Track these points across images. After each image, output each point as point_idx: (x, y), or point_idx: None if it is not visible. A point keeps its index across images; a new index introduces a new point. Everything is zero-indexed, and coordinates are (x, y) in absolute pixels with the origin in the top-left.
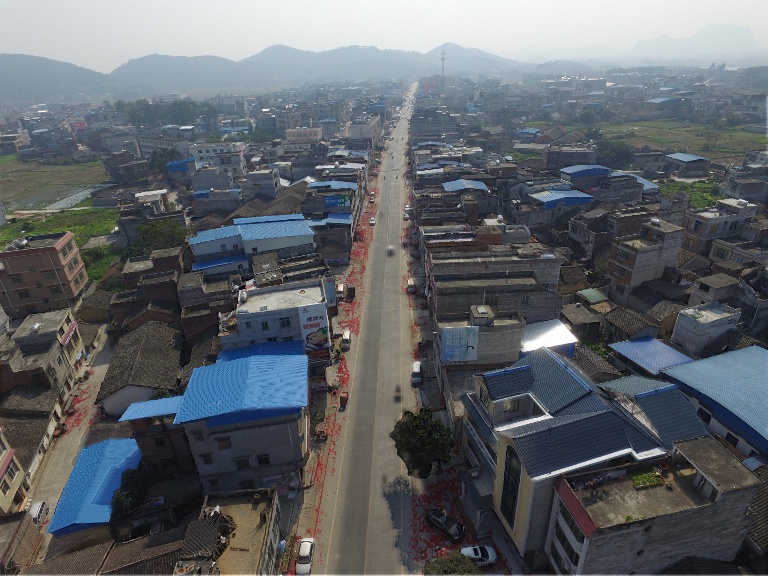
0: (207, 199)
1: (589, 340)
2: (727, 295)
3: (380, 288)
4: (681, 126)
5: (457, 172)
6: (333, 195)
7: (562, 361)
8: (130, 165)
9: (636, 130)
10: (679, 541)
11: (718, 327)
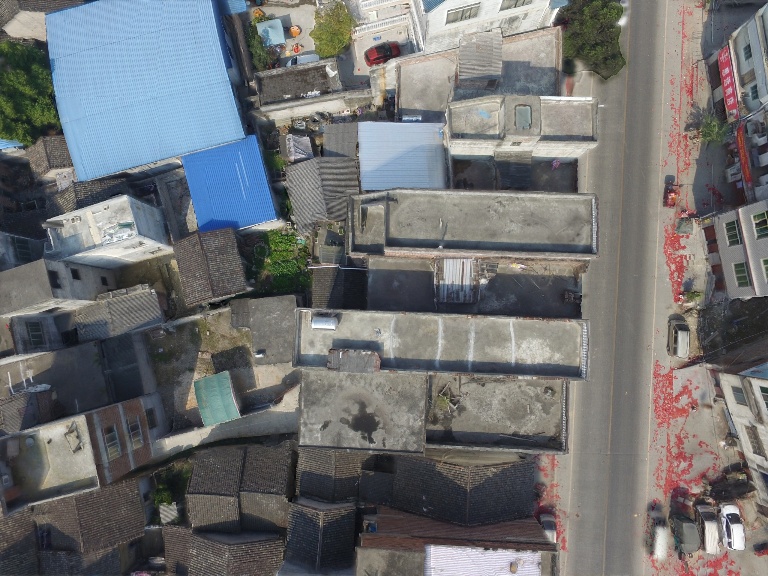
0: None
1: (277, 289)
2: None
3: (614, 547)
4: None
5: None
6: None
7: None
8: None
9: None
10: None
11: None
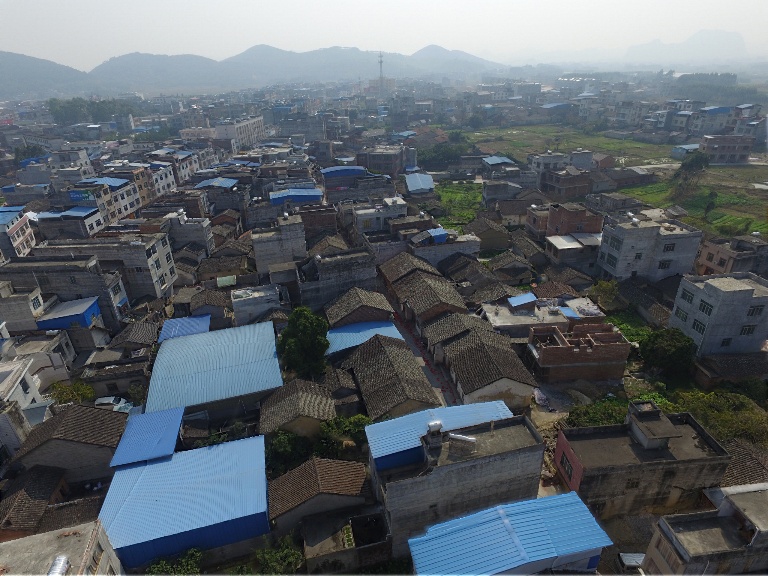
0: (13, 193)
1: None
2: (289, 279)
3: None
4: (556, 131)
5: (224, 171)
6: (77, 190)
7: None
8: None
9: (512, 134)
10: None
11: (255, 305)
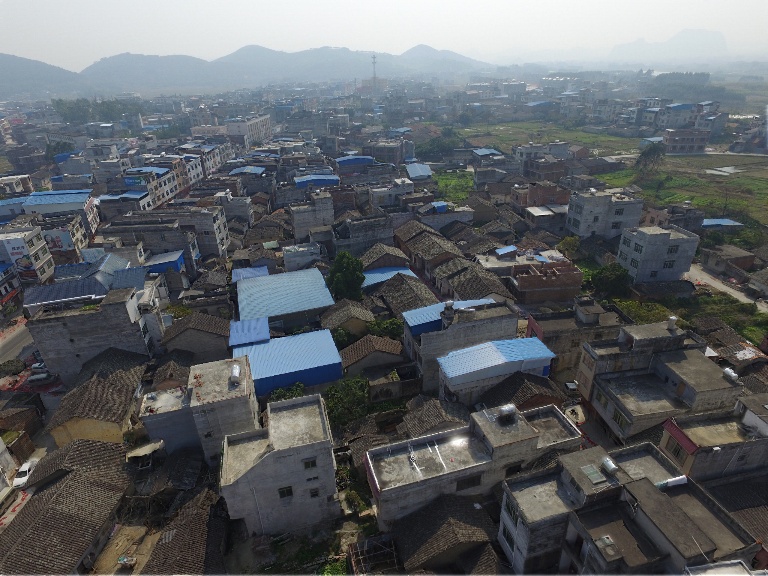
0: (61, 183)
1: None
2: (326, 238)
3: None
4: (539, 127)
5: (252, 161)
6: (131, 176)
7: (111, 260)
8: (30, 157)
9: (499, 130)
10: (95, 335)
11: (302, 257)
